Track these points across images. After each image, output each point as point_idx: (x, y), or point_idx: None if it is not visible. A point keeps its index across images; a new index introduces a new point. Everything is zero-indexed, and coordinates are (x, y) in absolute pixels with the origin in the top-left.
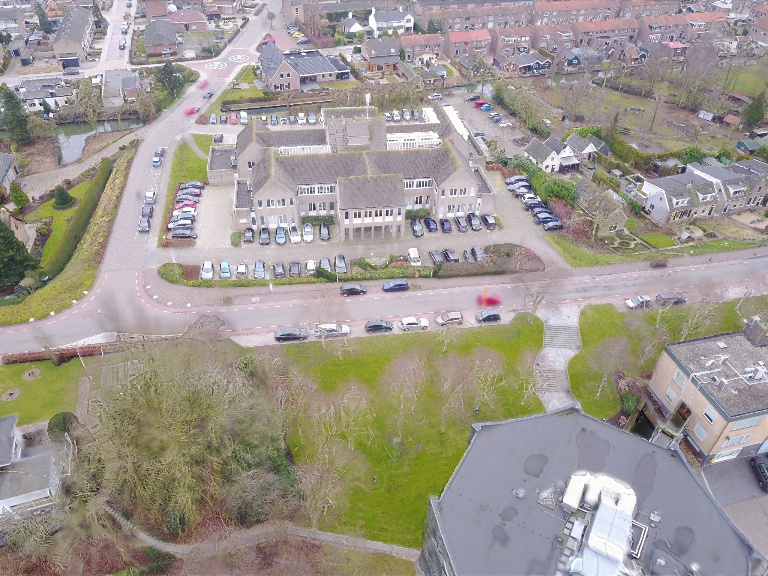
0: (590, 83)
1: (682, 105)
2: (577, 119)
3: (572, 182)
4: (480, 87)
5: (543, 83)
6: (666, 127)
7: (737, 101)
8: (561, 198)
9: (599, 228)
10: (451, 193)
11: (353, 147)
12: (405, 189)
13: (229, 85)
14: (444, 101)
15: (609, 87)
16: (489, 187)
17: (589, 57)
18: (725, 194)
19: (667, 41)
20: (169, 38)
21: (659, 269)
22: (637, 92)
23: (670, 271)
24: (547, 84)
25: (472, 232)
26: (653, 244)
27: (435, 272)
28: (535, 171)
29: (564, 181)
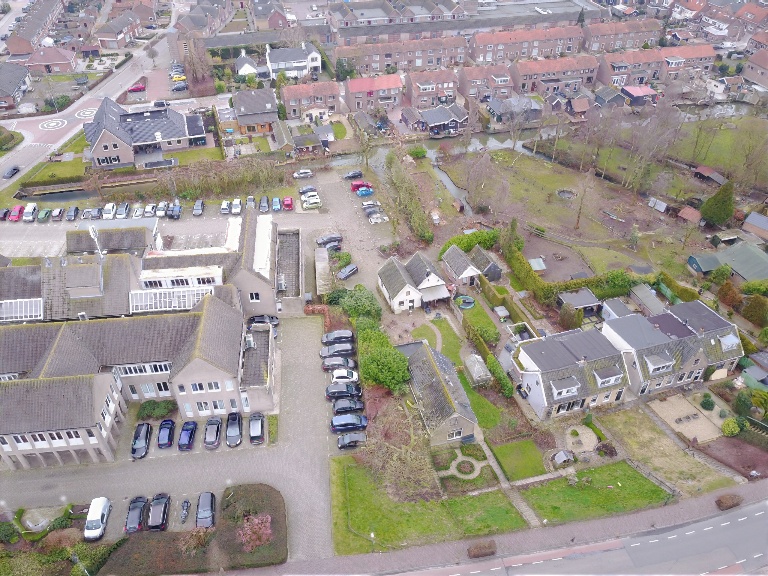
0: (520, 147)
1: (630, 186)
2: (480, 210)
3: (402, 356)
4: (380, 151)
5: (454, 150)
6: (599, 223)
7: (706, 180)
8: (382, 382)
9: (431, 437)
10: (195, 388)
11: (77, 301)
12: (134, 375)
13: (49, 155)
14: (314, 180)
15: (542, 154)
16: (267, 369)
17: (515, 117)
18: (641, 371)
19: (632, 86)
20: (4, 88)
21: (480, 561)
22: (575, 164)
23: (497, 567)
24: (460, 151)
25: (224, 449)
26: (509, 470)
27: (92, 571)
28: (359, 329)
29: (389, 355)
